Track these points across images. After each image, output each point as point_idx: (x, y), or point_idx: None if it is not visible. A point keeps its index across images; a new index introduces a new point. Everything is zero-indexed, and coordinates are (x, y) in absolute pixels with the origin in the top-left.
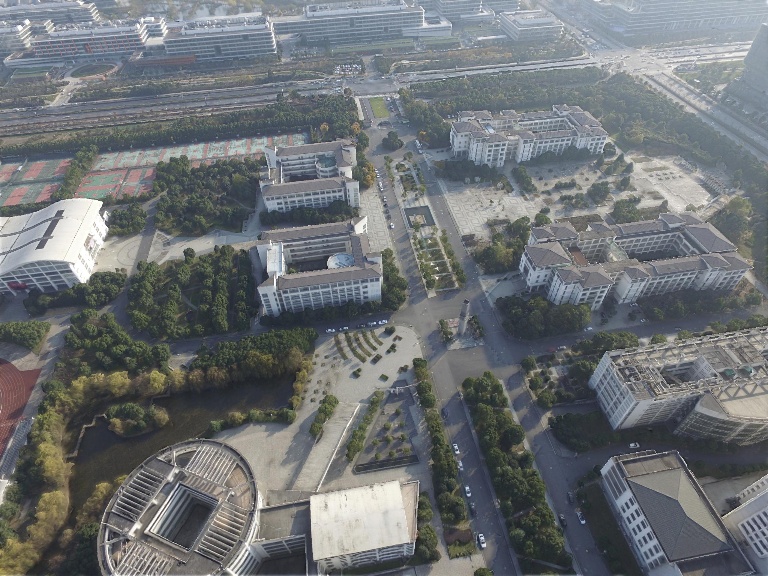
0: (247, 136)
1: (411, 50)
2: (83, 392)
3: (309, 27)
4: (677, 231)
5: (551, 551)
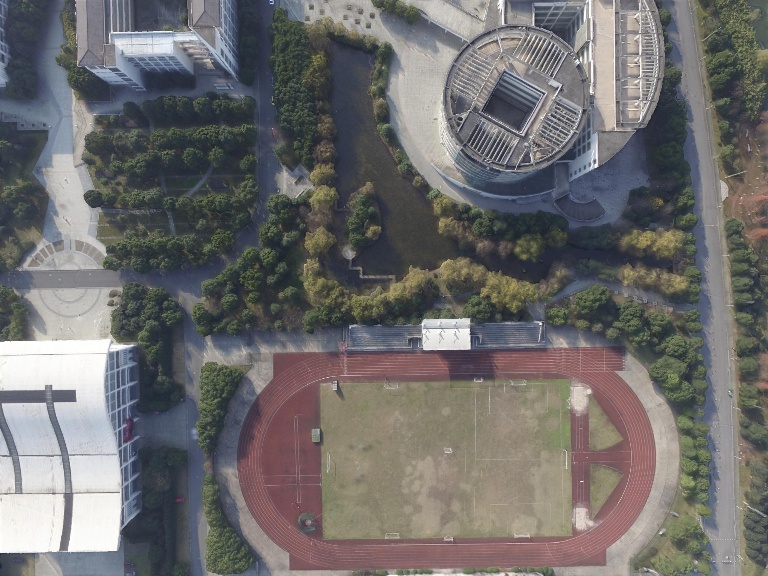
0: None
1: None
2: None
3: None
4: None
5: None
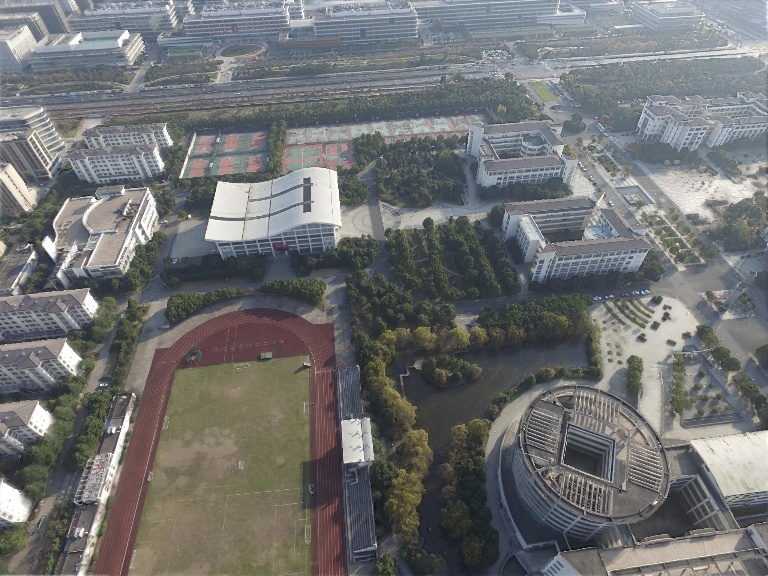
0: (425, 116)
1: (550, 37)
2: (394, 344)
3: (447, 12)
4: None
5: None
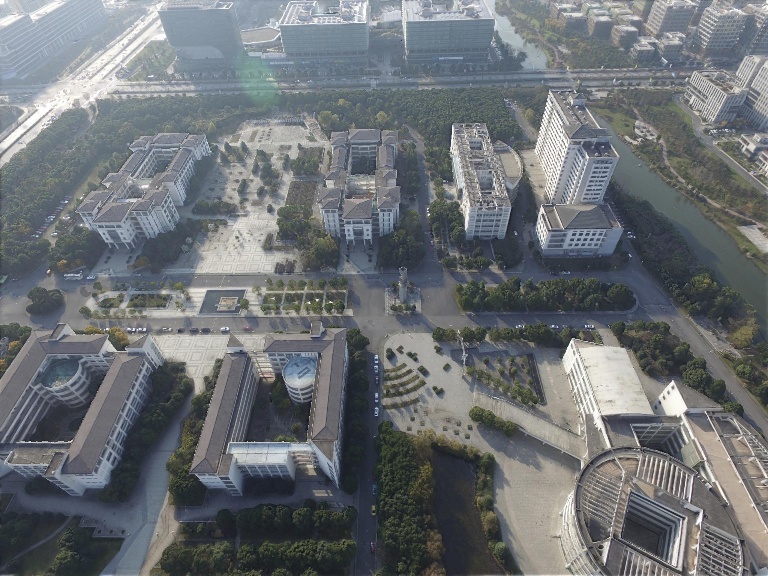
0: None
1: None
2: None
3: None
4: (350, 146)
5: (599, 286)
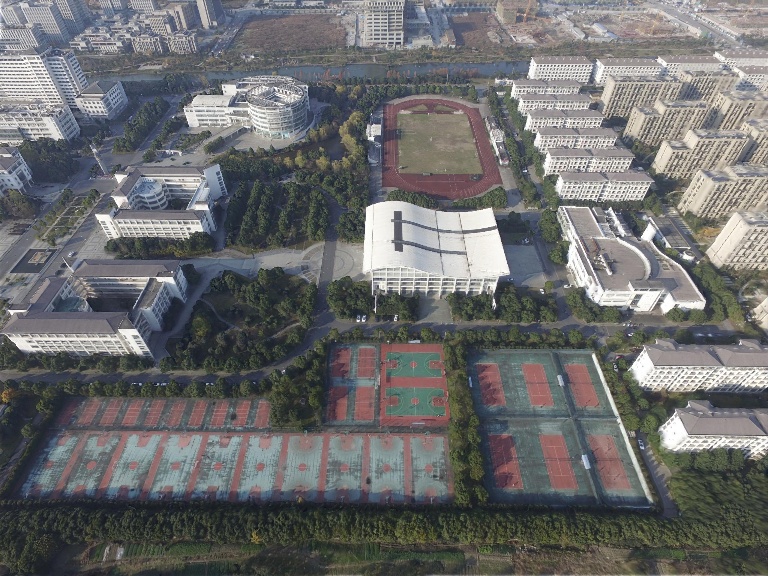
0: None
1: None
2: None
3: None
4: None
5: None
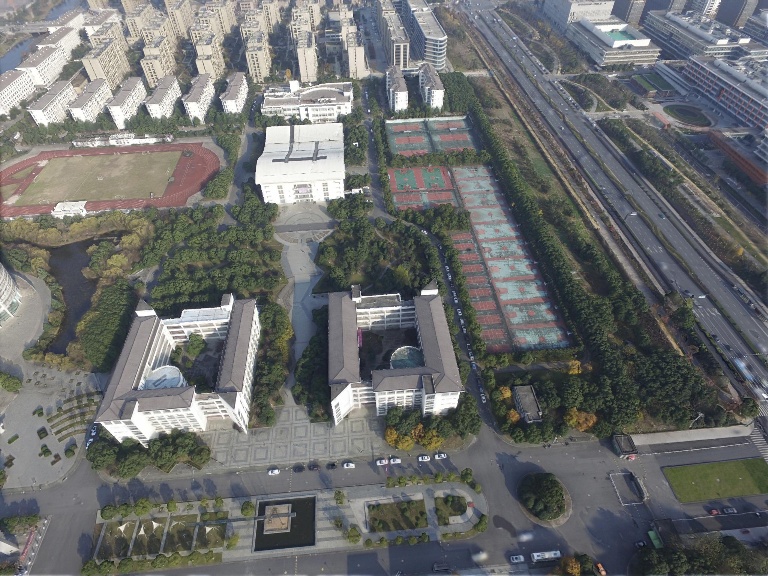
0: (542, 273)
1: None
2: None
3: None
4: None
5: None
